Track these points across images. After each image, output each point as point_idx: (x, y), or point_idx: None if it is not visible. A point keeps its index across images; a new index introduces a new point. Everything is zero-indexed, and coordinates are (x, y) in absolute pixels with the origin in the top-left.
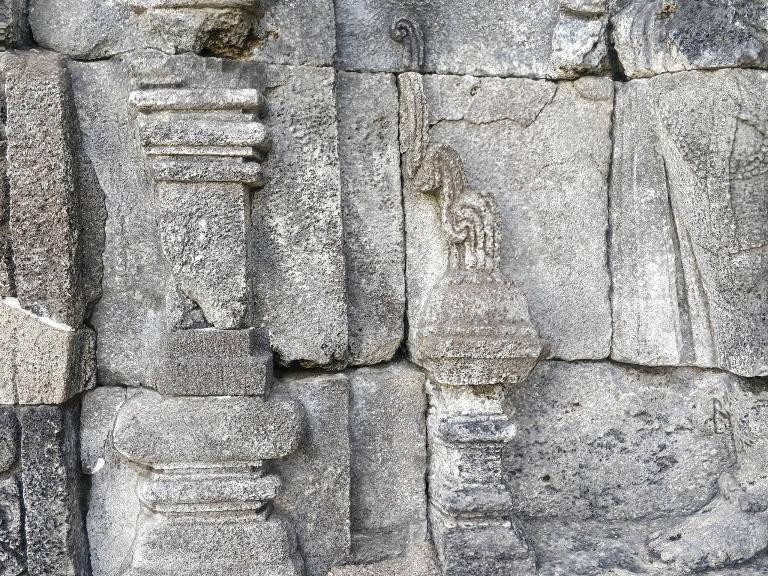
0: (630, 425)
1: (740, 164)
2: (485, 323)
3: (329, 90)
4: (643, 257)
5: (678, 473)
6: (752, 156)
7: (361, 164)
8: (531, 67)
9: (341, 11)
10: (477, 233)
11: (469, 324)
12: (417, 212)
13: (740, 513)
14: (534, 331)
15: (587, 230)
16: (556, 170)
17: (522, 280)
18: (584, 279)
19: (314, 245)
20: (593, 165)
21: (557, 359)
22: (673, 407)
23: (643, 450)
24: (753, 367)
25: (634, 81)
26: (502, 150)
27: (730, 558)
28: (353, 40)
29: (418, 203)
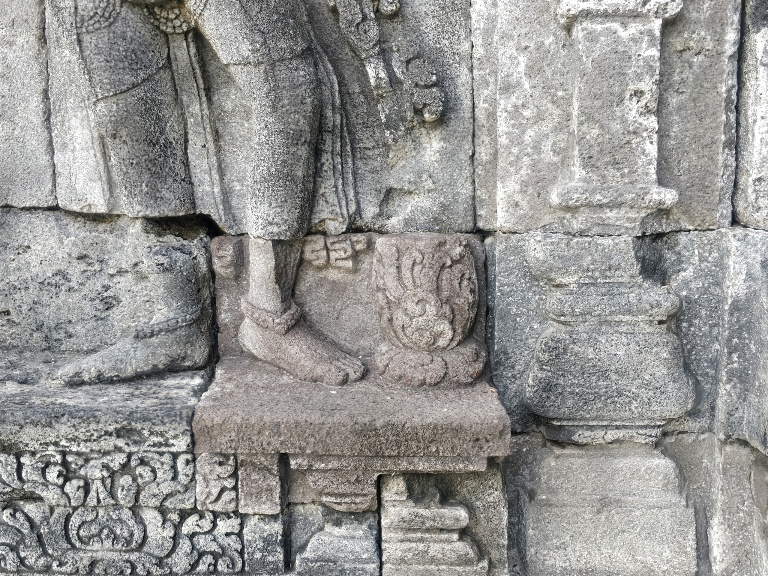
0: (75, 266)
1: (84, 19)
2: None
3: None
4: (68, 113)
5: (122, 311)
6: (92, 11)
7: None
8: None
9: None
10: None
11: None
12: None
13: (130, 339)
14: None
15: (27, 89)
16: None
17: None
18: (26, 134)
19: None
20: (30, 30)
21: (12, 207)
22: (116, 252)
23: (88, 289)
24: (132, 208)
25: None
26: None
27: (104, 375)
28: None
29: None
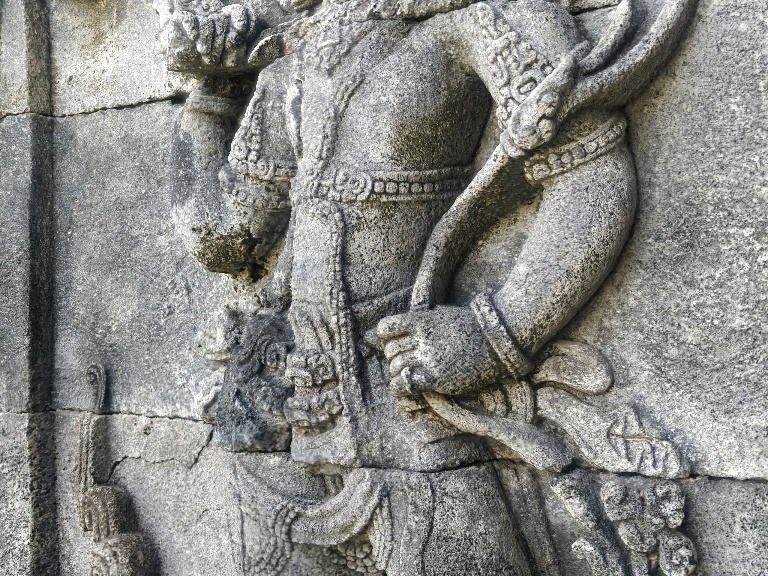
0: None
1: None
2: None
3: (24, 434)
4: None
5: None
6: (258, 555)
7: (71, 493)
8: (190, 409)
9: (58, 358)
10: None
11: None
12: None
13: None
14: None
15: None
16: (214, 516)
17: None
18: None
19: (12, 569)
20: None
21: None
22: None
23: None
24: None
25: None
26: (172, 490)
27: None
28: (66, 383)
29: None
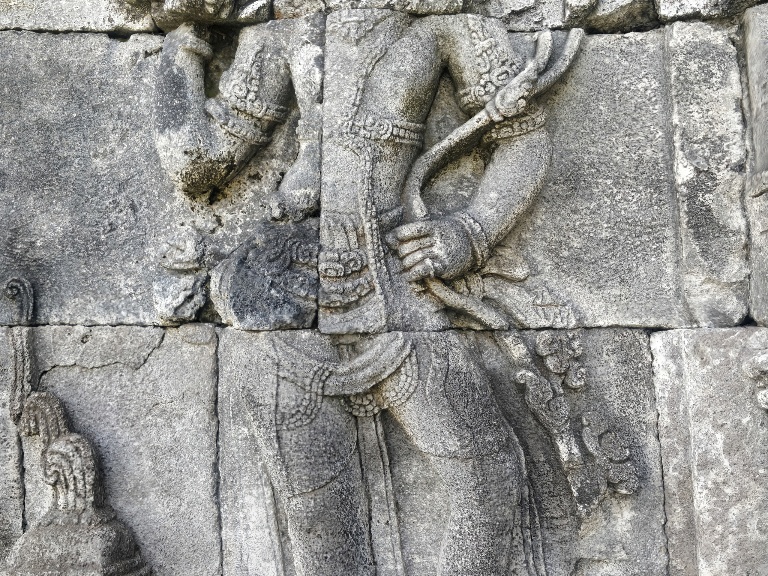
0: None
1: (285, 416)
2: (56, 567)
3: None
4: (242, 490)
5: None
6: (294, 409)
7: None
8: (139, 316)
9: None
10: (66, 477)
11: (41, 568)
12: (33, 451)
13: None
14: (99, 575)
15: (196, 463)
16: (166, 408)
17: (135, 512)
18: (193, 510)
19: None
20: (200, 403)
21: None
22: None
23: None
24: None
25: (226, 329)
26: (114, 391)
27: None
28: None
29: (34, 442)
